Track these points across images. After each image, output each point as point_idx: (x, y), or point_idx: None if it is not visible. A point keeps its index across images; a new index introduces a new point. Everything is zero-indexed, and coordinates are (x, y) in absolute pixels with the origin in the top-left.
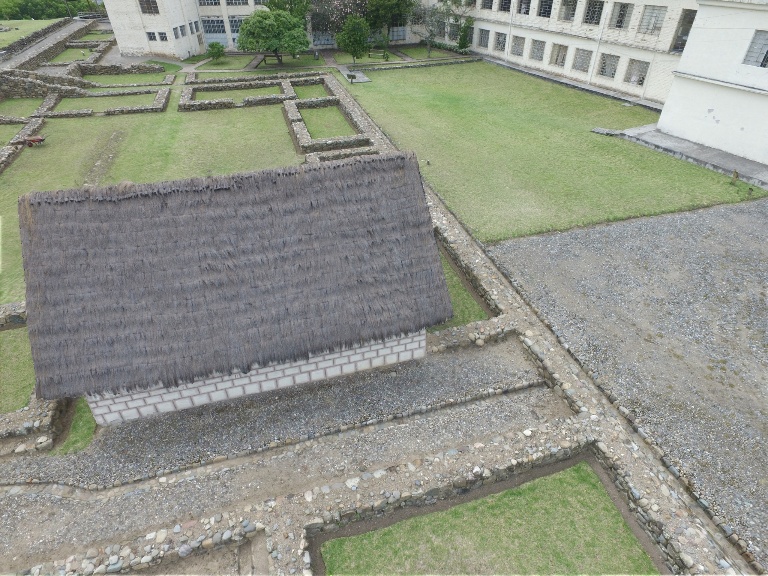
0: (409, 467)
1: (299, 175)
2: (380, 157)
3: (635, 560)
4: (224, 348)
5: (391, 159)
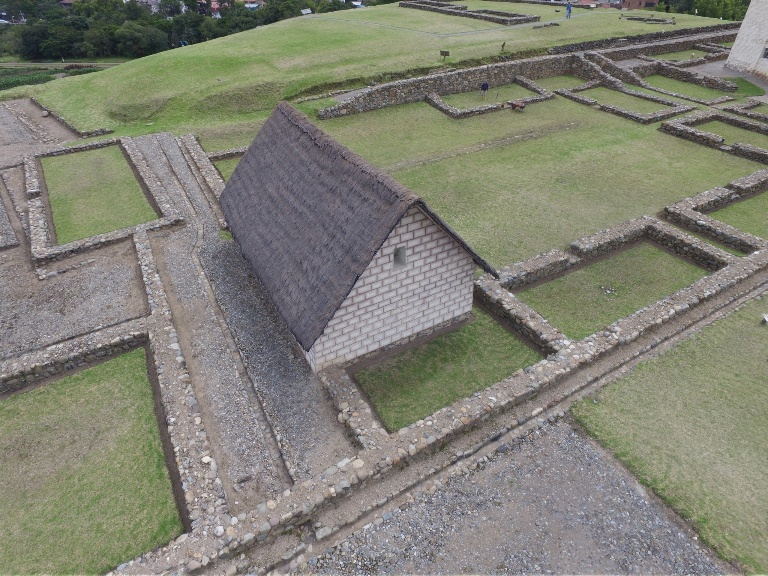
0: (182, 375)
1: (346, 162)
2: (389, 184)
3: (73, 571)
4: (247, 235)
5: (391, 191)
